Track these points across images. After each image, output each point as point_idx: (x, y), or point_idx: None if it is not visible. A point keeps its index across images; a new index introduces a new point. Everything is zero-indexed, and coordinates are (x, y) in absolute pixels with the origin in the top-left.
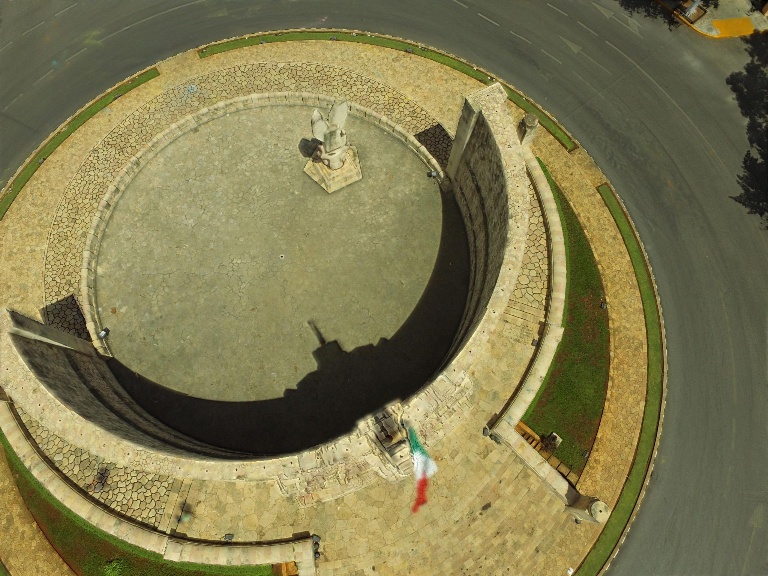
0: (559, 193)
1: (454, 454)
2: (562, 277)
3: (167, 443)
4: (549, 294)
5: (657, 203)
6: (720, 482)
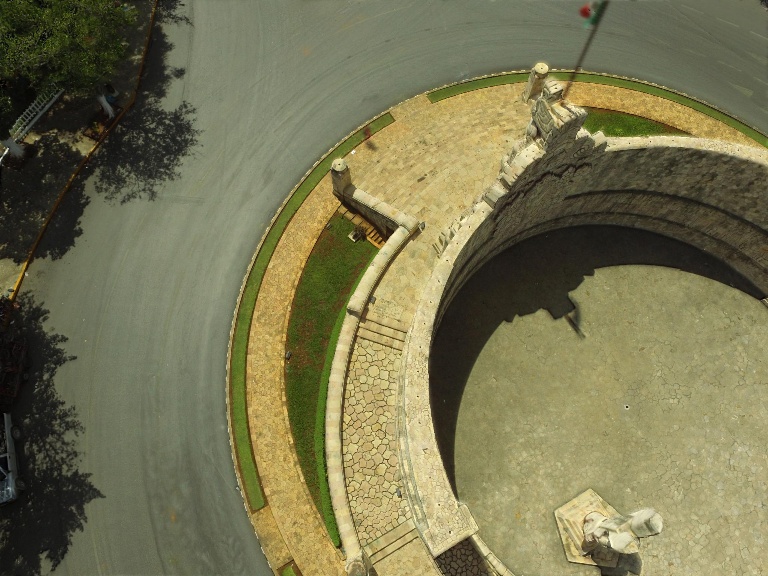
0: (314, 495)
1: (450, 210)
2: (337, 368)
3: (696, 201)
4: (351, 354)
5: (196, 486)
6: (219, 210)
